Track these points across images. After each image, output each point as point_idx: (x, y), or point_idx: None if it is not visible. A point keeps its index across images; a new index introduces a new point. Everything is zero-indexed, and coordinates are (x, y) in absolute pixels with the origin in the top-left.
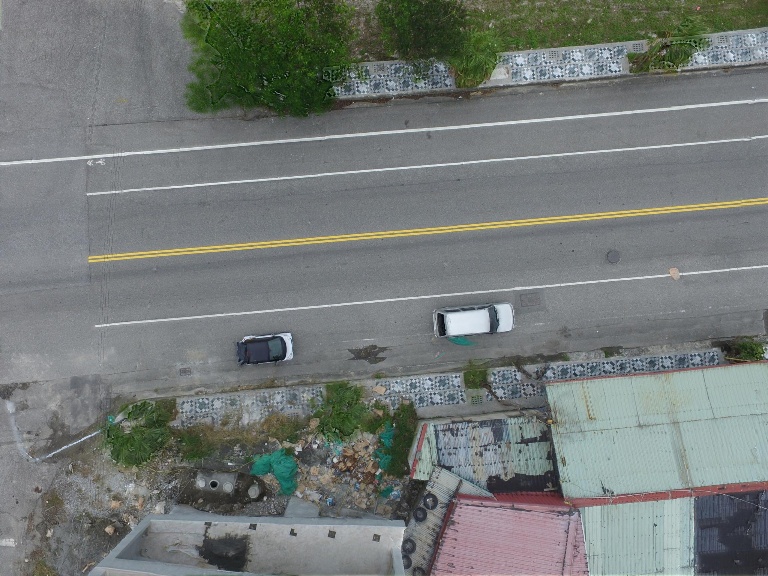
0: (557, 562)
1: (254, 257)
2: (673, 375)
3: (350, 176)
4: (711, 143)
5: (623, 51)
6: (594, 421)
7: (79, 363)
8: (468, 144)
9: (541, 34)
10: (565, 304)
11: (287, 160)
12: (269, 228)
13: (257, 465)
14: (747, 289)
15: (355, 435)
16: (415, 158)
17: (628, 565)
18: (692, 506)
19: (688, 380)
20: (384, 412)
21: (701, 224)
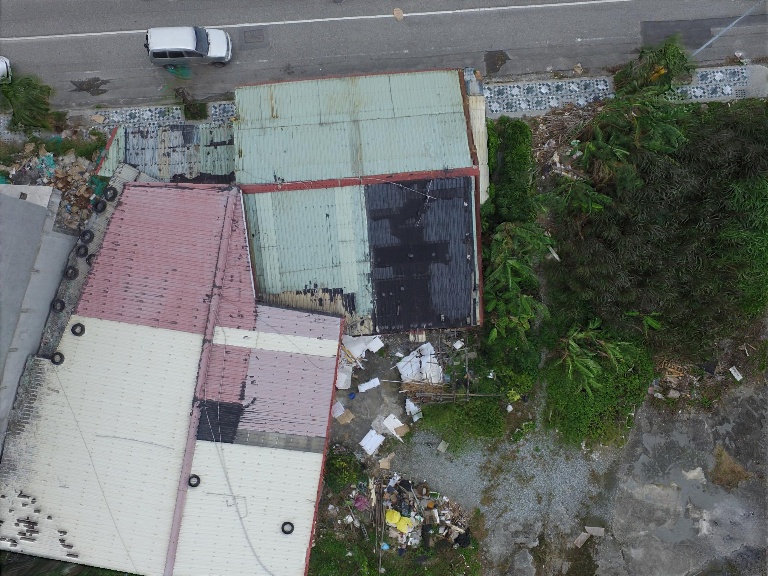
0: (215, 236)
1: None
2: (359, 79)
3: None
4: None
5: None
6: (276, 119)
7: None
8: None
9: None
10: (289, 42)
11: None
12: None
13: None
14: (469, 31)
15: (69, 158)
16: None
17: (304, 258)
18: (362, 195)
19: (374, 85)
20: (99, 137)
21: None
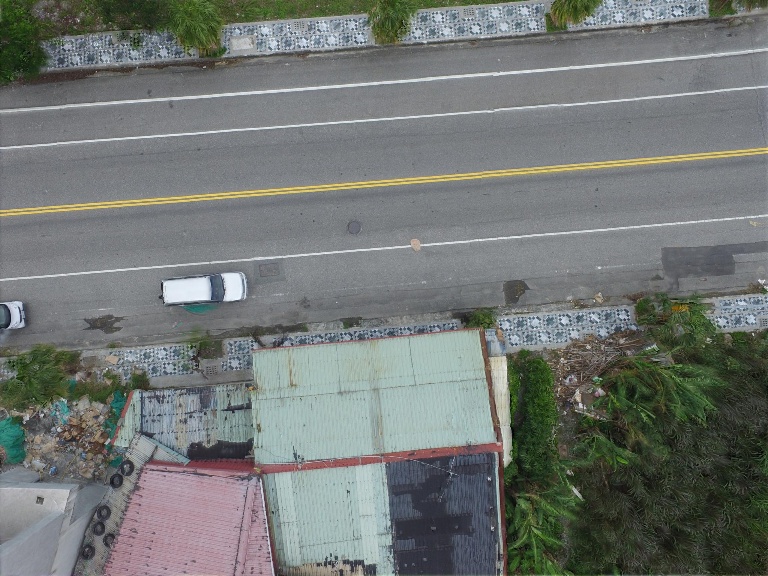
0: (235, 527)
1: None
2: (378, 342)
3: (90, 145)
4: (454, 115)
5: (369, 22)
6: (295, 387)
7: None
8: (211, 114)
9: (289, 5)
10: (305, 275)
11: (26, 128)
12: (5, 196)
13: None
14: (487, 260)
15: (83, 404)
16: (156, 127)
17: (324, 532)
18: (384, 472)
19: (394, 347)
20: (113, 381)
21: (443, 195)
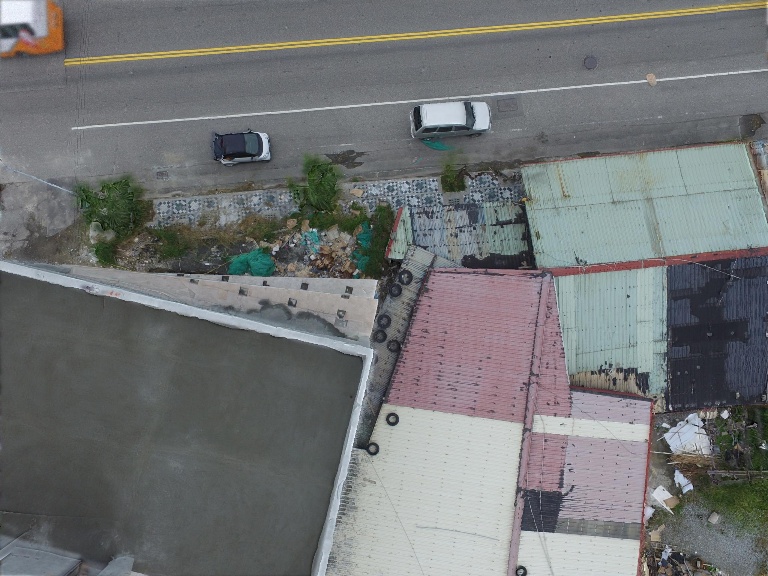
0: (530, 323)
1: (231, 61)
2: (647, 155)
3: None
4: None
5: None
6: (568, 198)
7: (55, 165)
8: None
9: None
10: (542, 110)
11: None
12: (246, 33)
13: (234, 264)
14: (723, 95)
15: (332, 234)
16: None
17: (602, 339)
18: (665, 276)
19: (662, 161)
20: (361, 212)
21: (678, 31)
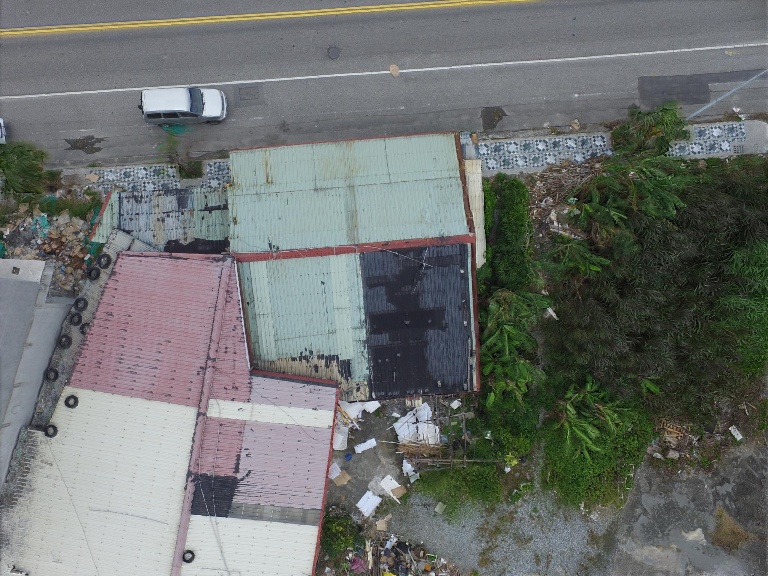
0: (210, 307)
1: None
2: (354, 143)
3: None
4: None
5: None
6: (271, 184)
7: None
8: None
9: None
10: (284, 99)
11: None
12: None
13: None
14: (466, 87)
15: (63, 219)
16: None
17: (299, 325)
18: (358, 263)
19: (370, 149)
20: (93, 197)
21: (422, 22)
